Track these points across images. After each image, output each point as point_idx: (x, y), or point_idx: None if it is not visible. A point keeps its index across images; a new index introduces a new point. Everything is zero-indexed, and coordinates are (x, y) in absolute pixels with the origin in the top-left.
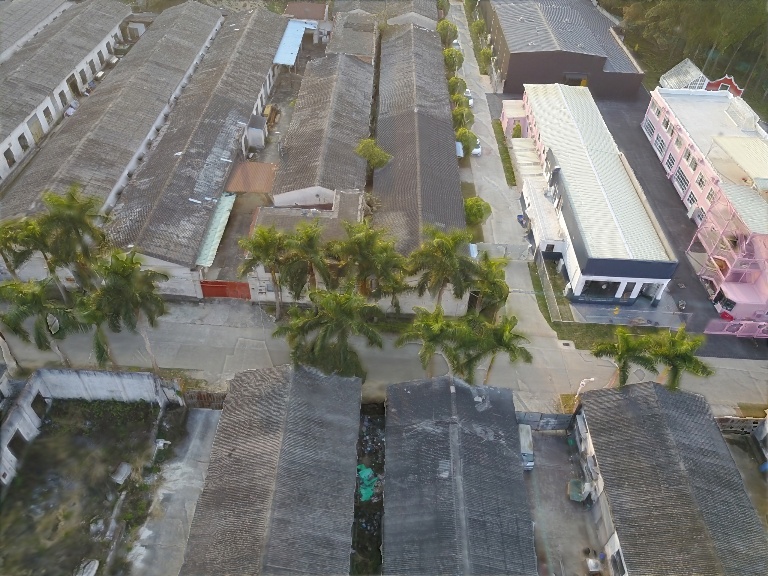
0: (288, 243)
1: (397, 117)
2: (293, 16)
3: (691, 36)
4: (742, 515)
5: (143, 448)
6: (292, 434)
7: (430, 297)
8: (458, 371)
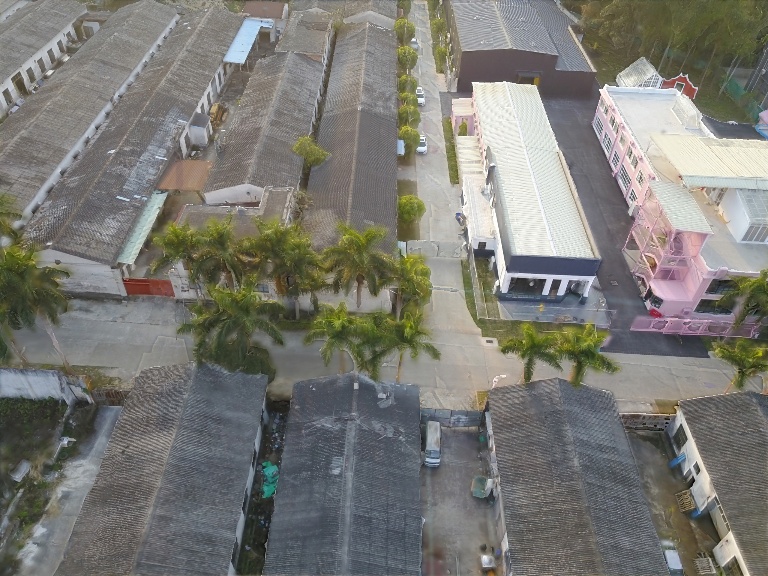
0: (197, 240)
1: (340, 115)
2: (249, 15)
3: (645, 34)
4: (633, 511)
5: (45, 446)
6: (186, 431)
7: (349, 294)
8: (363, 368)
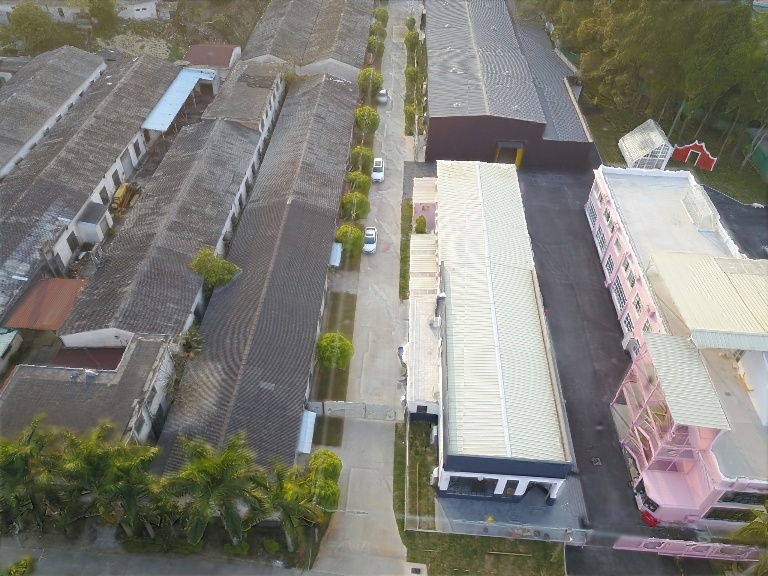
0: None
1: (265, 209)
2: (188, 63)
3: (653, 95)
4: None
5: None
6: None
7: None
8: None
